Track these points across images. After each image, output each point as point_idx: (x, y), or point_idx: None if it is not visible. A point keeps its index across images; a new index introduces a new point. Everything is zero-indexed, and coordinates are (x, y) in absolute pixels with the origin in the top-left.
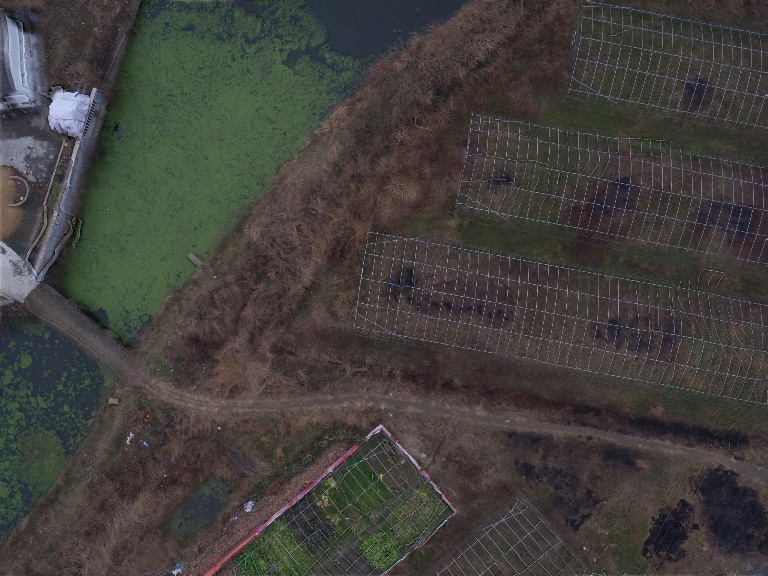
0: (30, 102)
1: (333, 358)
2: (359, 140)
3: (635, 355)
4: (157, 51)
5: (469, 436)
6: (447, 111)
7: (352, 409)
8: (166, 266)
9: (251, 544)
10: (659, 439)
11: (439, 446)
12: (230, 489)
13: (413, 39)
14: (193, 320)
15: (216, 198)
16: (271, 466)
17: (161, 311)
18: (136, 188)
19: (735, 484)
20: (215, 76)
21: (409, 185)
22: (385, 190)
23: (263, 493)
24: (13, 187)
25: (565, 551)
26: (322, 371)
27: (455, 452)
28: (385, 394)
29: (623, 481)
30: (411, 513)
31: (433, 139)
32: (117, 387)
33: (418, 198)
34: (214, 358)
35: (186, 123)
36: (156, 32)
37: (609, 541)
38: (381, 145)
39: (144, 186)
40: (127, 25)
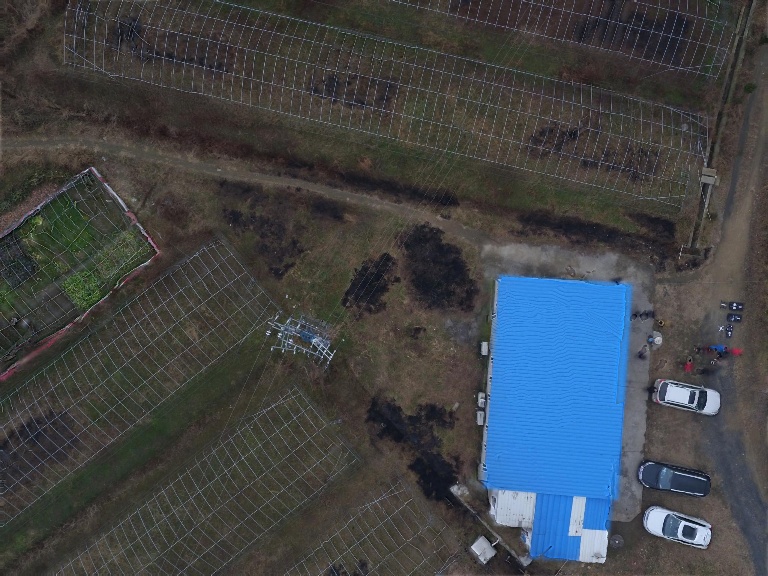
0: None
1: (52, 103)
2: None
3: (332, 97)
4: None
5: (180, 183)
6: None
7: (65, 151)
8: None
9: None
10: (367, 194)
11: (150, 191)
12: None
13: None
14: None
15: None
16: None
17: None
18: None
19: (440, 241)
20: None
21: None
22: None
23: None
24: None
25: (251, 282)
26: (39, 113)
27: (164, 197)
28: (99, 138)
29: (328, 232)
30: (113, 250)
31: None
32: None
33: None
34: None
35: None
36: None
37: (311, 290)
38: None
39: None
40: None
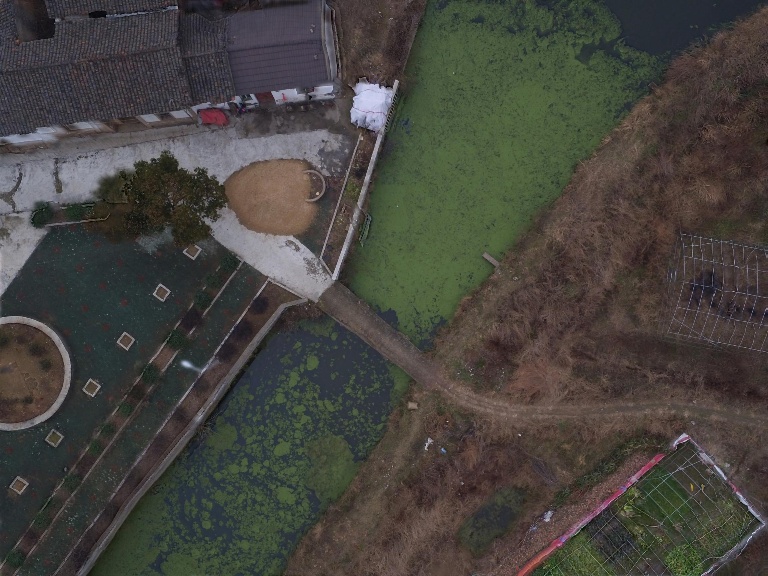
0: (332, 93)
1: (633, 364)
2: (661, 139)
3: None
4: (446, 43)
5: None
6: (758, 110)
7: (655, 417)
8: (458, 266)
9: (554, 555)
10: None
11: (743, 456)
12: (524, 498)
13: (716, 35)
14: (494, 322)
15: (509, 196)
16: (572, 475)
17: (457, 313)
18: (426, 185)
19: None
20: (506, 70)
21: (718, 186)
22: (691, 191)
23: (563, 502)
24: (309, 182)
25: None
26: (623, 377)
27: (761, 462)
28: (689, 401)
29: None
30: (721, 525)
31: (744, 139)
32: (415, 391)
33: (729, 200)
34: (514, 362)
35: (476, 118)
36: (445, 23)
37: None
38: (684, 144)
39: (434, 183)
40: (419, 15)
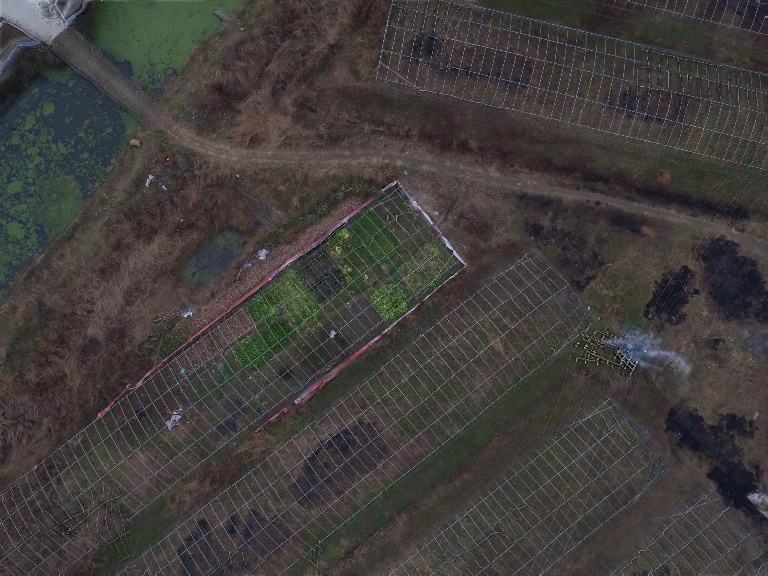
0: None
1: (352, 117)
2: None
3: (645, 113)
4: None
5: (481, 197)
6: None
7: (369, 165)
8: (192, 23)
9: (264, 288)
10: (664, 208)
11: (452, 205)
12: (245, 241)
13: None
14: (217, 70)
15: None
16: (287, 216)
17: (185, 62)
18: None
19: (735, 254)
20: None
21: None
22: None
23: (278, 241)
24: None
25: (572, 295)
26: (341, 127)
27: (467, 210)
28: (401, 152)
29: (628, 245)
30: (423, 263)
31: None
32: (139, 131)
33: None
34: (236, 109)
35: None
36: None
37: (613, 302)
38: None
39: None
40: None
